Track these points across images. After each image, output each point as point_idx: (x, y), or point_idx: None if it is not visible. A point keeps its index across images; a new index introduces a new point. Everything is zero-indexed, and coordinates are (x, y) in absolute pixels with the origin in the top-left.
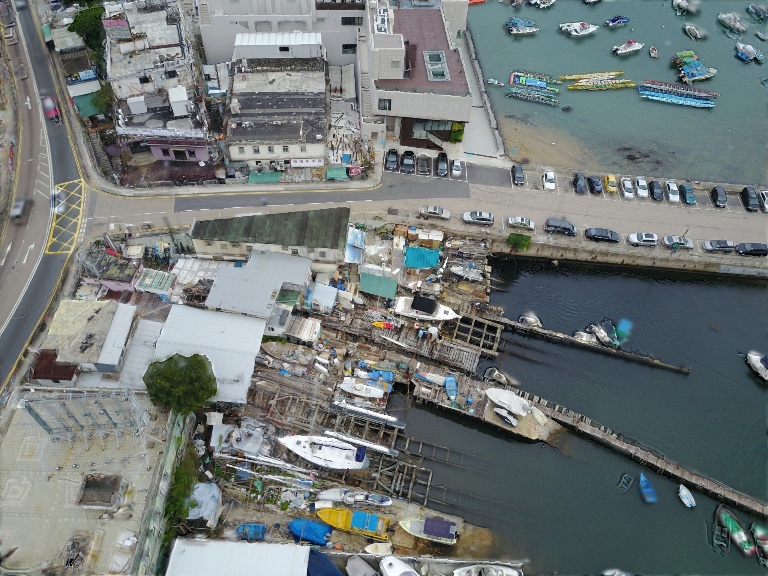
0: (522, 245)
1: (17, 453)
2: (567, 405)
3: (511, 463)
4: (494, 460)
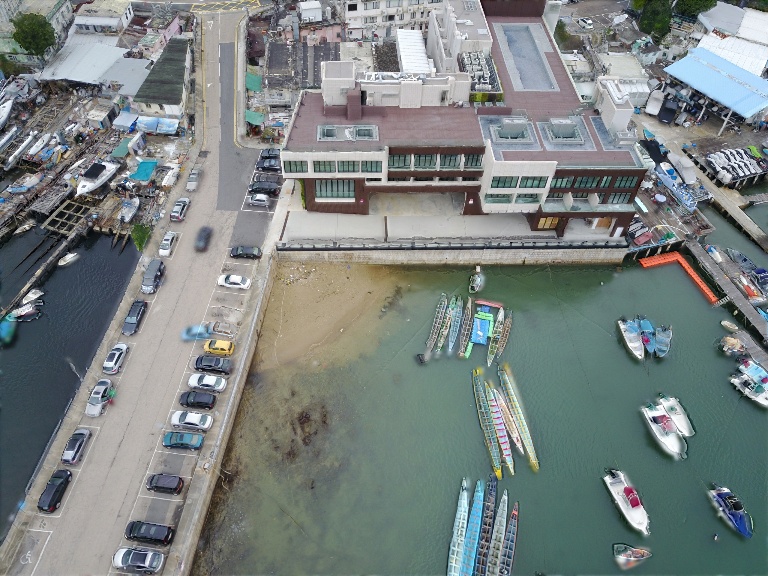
0: None
1: (28, 0)
2: None
3: None
4: None
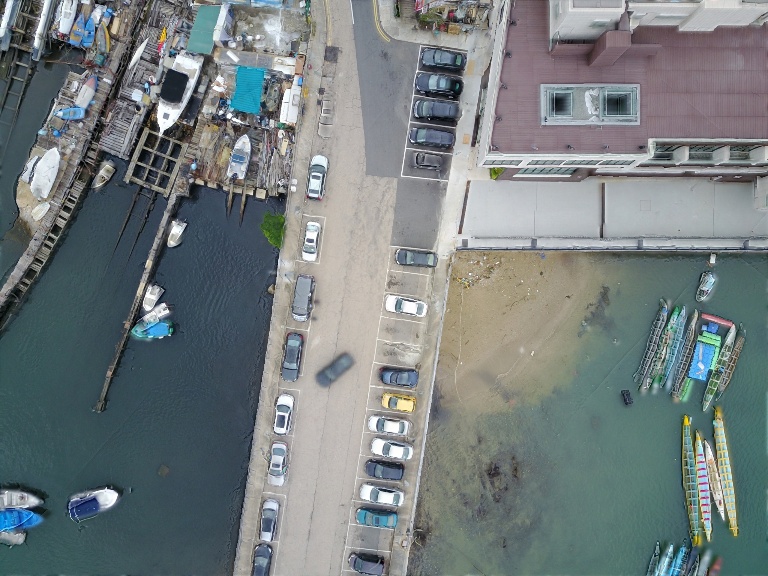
0: (263, 231)
1: None
2: (78, 259)
3: (0, 175)
4: (4, 157)
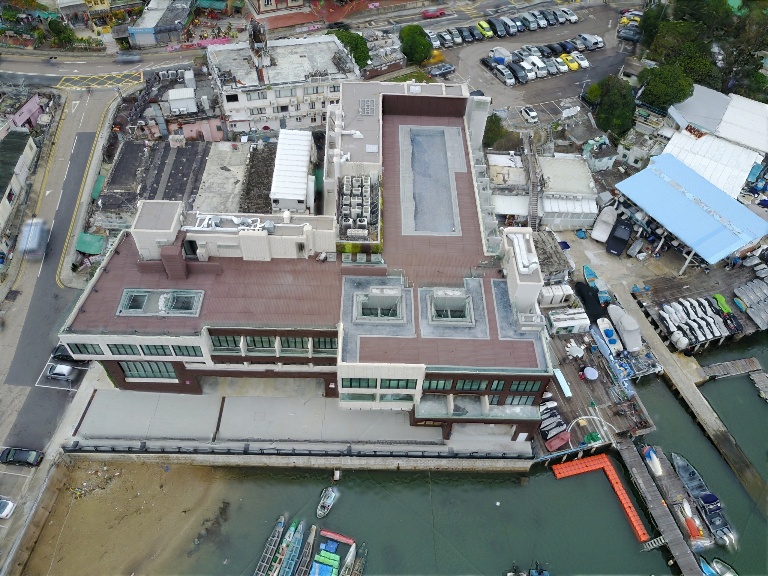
0: None
1: None
2: None
3: None
4: None
